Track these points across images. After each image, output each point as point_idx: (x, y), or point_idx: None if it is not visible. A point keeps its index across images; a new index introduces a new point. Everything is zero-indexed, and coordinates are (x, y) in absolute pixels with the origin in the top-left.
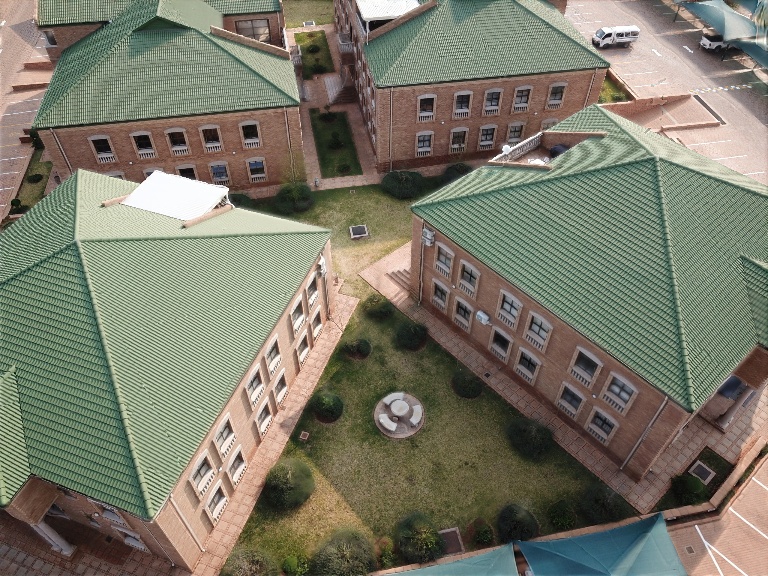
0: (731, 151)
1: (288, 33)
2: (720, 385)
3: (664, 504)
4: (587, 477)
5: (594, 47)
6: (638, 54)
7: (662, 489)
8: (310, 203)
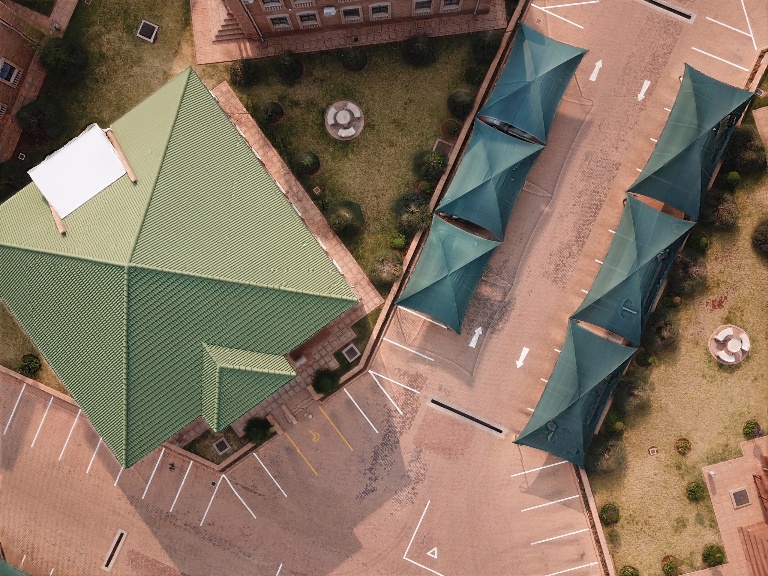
0: None
1: None
2: None
3: (509, 10)
4: (464, 39)
5: None
6: None
7: (502, 2)
8: (81, 50)
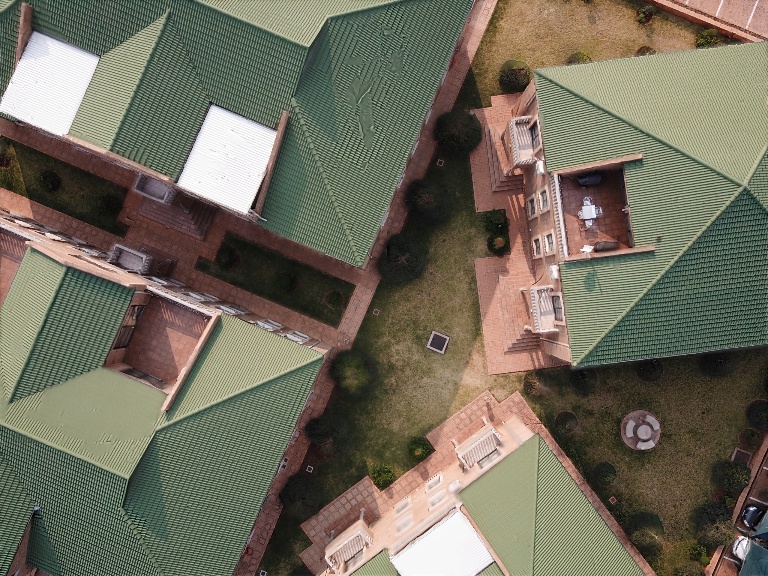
0: None
1: None
2: None
3: None
4: (762, 348)
5: None
6: None
7: None
8: (371, 363)
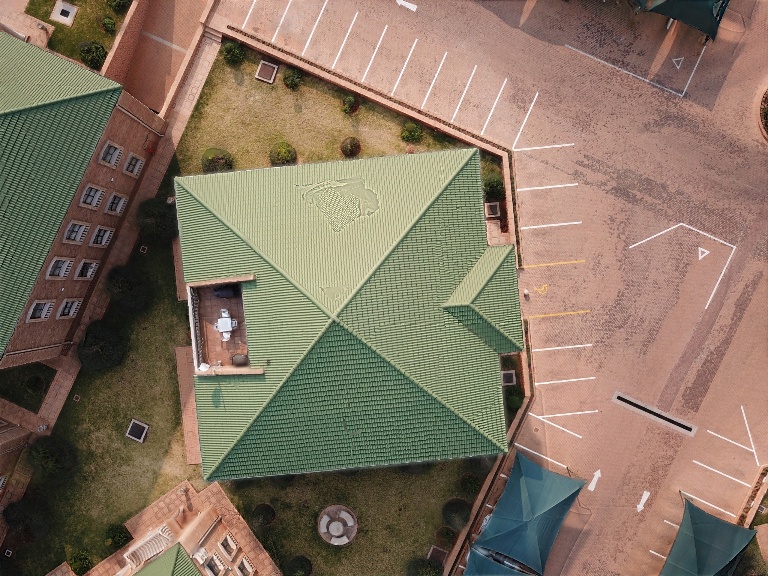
0: None
1: None
2: None
3: (506, 419)
4: None
5: None
6: None
7: None
8: (69, 450)
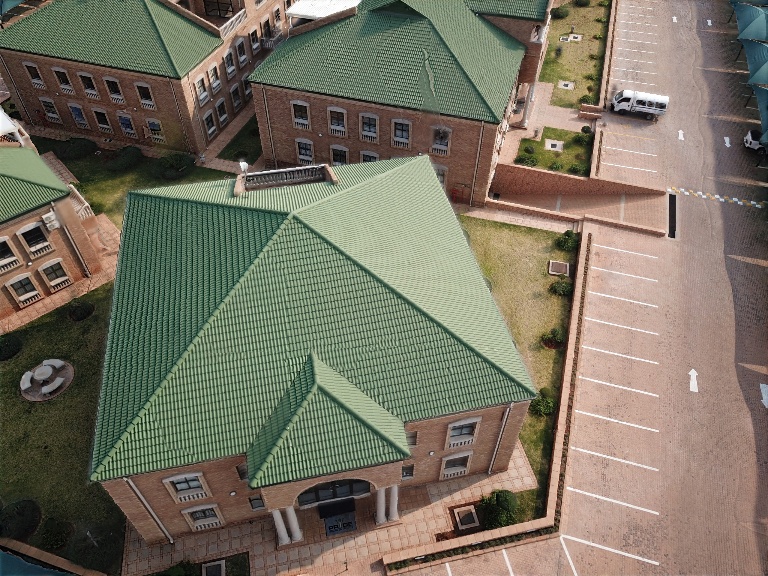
0: (643, 269)
1: None
2: (326, 501)
3: None
4: (118, 515)
5: (608, 109)
6: (655, 130)
7: (163, 566)
8: (181, 175)
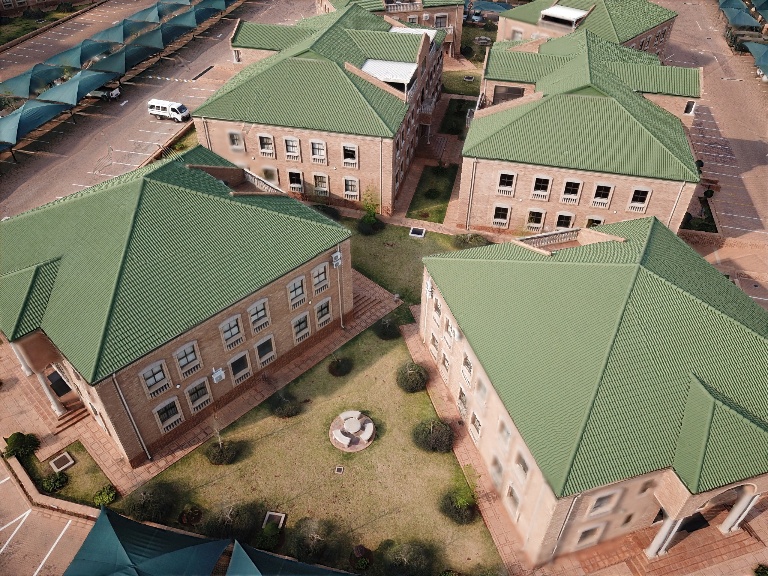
0: None
1: (450, 226)
2: None
3: None
4: None
5: None
6: None
7: None
8: None
